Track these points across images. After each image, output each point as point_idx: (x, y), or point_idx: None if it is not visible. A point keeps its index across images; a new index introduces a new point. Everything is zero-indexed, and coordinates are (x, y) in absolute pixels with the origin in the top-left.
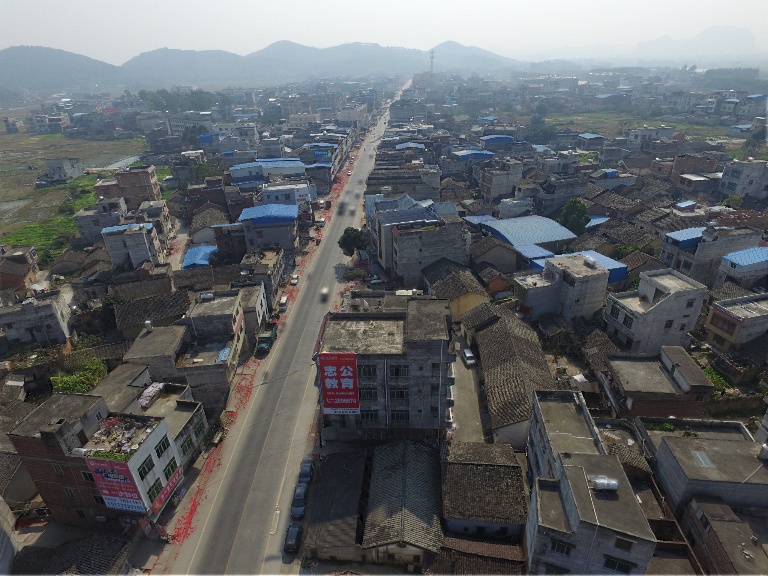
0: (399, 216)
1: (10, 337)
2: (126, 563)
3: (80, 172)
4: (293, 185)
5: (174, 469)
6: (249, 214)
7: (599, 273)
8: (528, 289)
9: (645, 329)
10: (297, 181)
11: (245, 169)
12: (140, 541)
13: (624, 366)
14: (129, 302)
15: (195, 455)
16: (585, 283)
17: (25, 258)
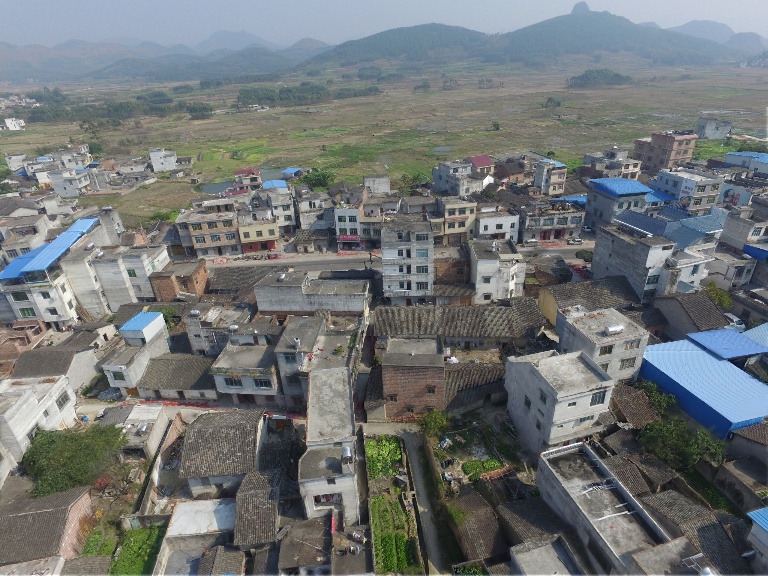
0: (637, 219)
1: (446, 188)
2: (325, 245)
3: (722, 135)
4: (704, 177)
5: (356, 234)
6: (603, 179)
7: (586, 335)
8: (557, 311)
9: (511, 383)
10: (714, 175)
11: (740, 157)
12: (337, 247)
13: (429, 346)
14: (478, 194)
15: (378, 246)
16: (572, 335)
17: (524, 165)
